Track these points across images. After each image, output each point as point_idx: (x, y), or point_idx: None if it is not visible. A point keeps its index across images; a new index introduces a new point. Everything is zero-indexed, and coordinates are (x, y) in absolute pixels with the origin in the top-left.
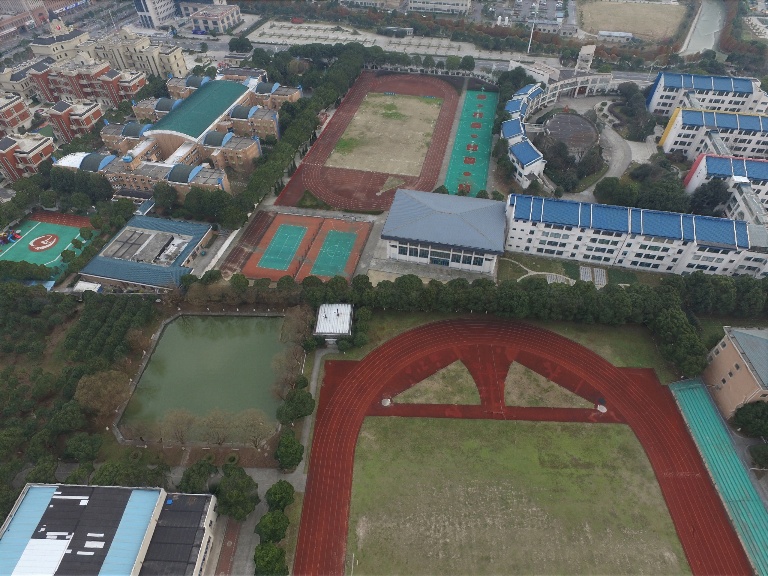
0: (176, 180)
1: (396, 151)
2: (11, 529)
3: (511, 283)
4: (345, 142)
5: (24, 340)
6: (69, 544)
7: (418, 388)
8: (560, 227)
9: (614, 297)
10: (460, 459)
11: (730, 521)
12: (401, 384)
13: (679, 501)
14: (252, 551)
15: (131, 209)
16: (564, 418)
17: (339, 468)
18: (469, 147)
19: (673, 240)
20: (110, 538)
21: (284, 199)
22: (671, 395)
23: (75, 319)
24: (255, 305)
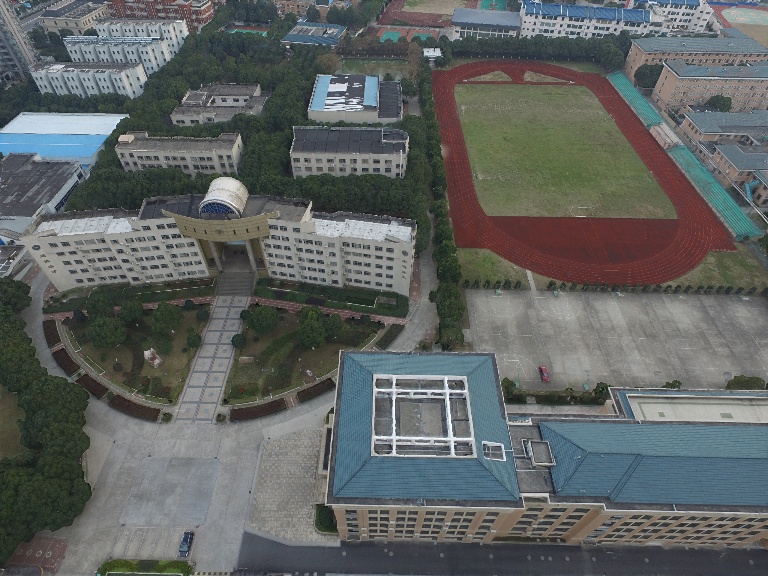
0: (321, 4)
1: (445, 6)
2: (319, 83)
3: None
4: (411, 2)
5: (264, 64)
6: (348, 84)
7: (480, 77)
8: (551, 18)
9: (579, 41)
10: (505, 93)
11: (628, 105)
12: (471, 76)
13: (606, 102)
14: (416, 111)
15: (296, 19)
16: (554, 84)
17: (448, 95)
18: (491, 5)
19: (611, 21)
20: (364, 84)
21: (382, 22)
22: (607, 79)
23: (286, 59)
24: (384, 54)
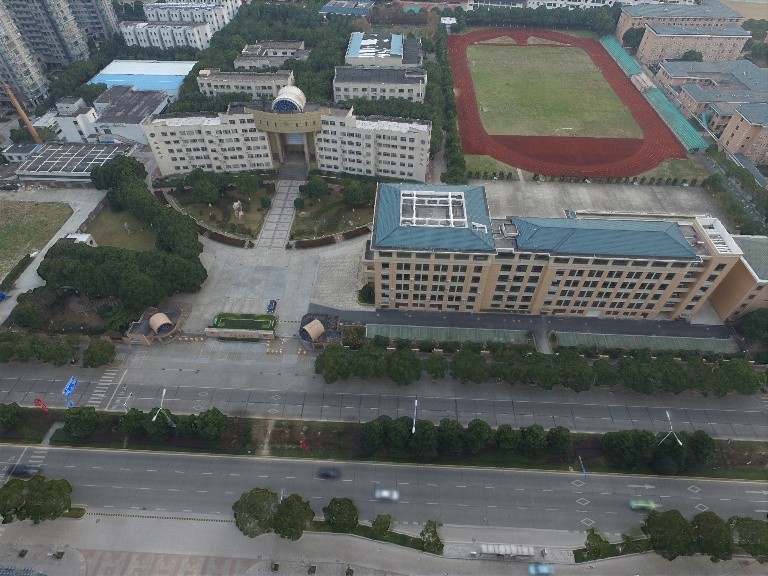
0: None
1: None
2: (353, 39)
3: (530, 7)
4: None
5: None
6: None
7: (489, 40)
8: None
9: (577, 11)
10: (510, 52)
11: (615, 61)
12: None
13: (597, 59)
14: None
15: None
16: (553, 46)
17: (461, 53)
18: None
19: None
20: None
21: None
22: (599, 42)
23: None
24: (407, 23)
